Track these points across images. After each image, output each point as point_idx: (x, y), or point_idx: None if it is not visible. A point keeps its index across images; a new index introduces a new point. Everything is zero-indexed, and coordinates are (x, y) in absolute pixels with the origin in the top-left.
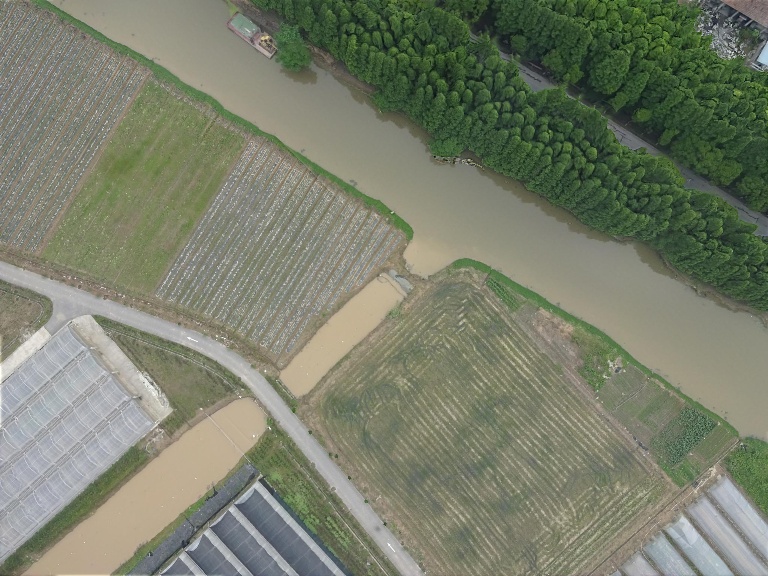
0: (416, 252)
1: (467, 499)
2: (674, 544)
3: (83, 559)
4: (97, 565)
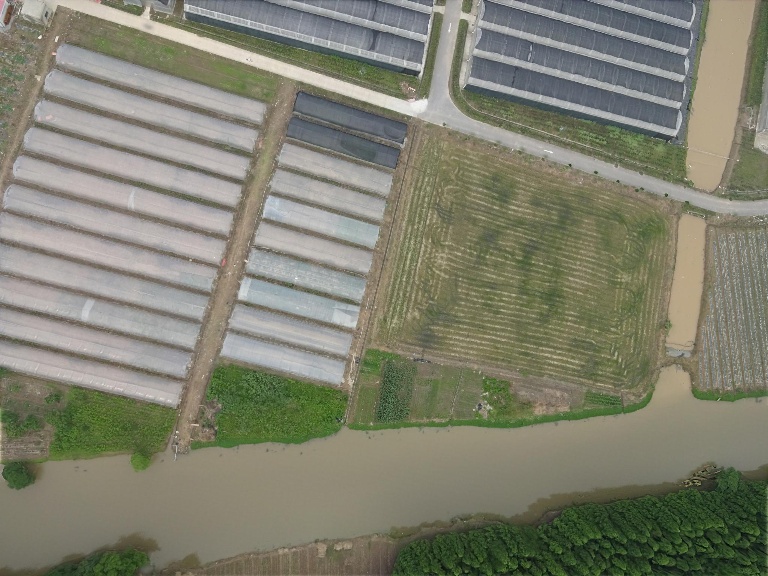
0: (681, 383)
1: (520, 224)
2: (343, 300)
3: (732, 8)
4: (722, 10)
